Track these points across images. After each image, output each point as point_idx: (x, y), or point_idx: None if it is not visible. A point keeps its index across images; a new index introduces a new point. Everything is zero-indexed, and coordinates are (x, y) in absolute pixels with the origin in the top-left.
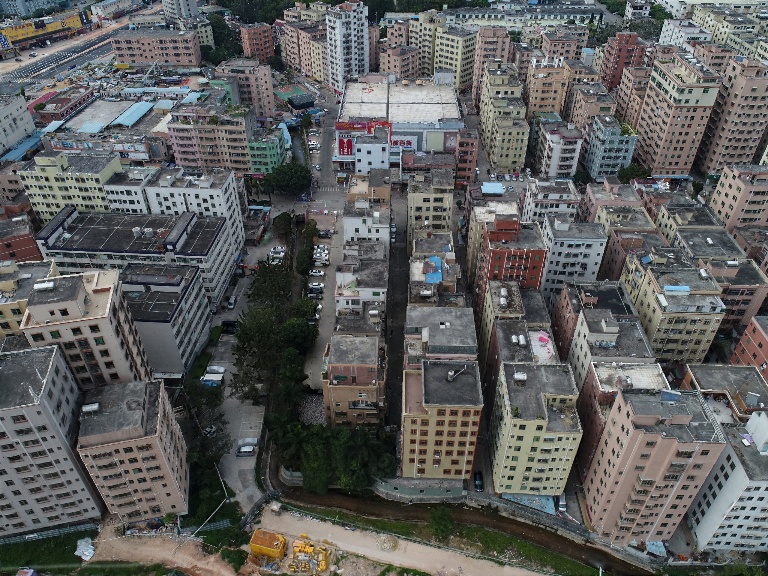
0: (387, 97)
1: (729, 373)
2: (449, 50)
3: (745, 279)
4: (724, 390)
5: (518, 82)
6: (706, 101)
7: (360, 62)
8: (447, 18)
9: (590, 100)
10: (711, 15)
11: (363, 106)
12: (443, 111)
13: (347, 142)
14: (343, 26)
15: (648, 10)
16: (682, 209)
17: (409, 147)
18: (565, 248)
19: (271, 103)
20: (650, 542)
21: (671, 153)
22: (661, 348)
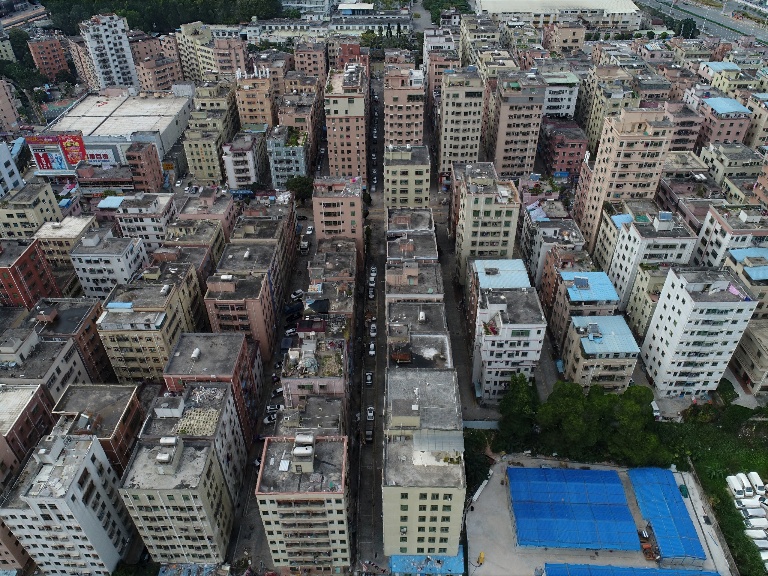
0: (114, 110)
1: (107, 393)
2: (208, 62)
3: (242, 294)
4: (77, 412)
5: (228, 94)
6: (355, 111)
7: (126, 75)
8: (251, 30)
9: (288, 111)
10: (465, 24)
11: (80, 120)
12: (155, 124)
13: (43, 156)
14: (93, 39)
15: (457, 19)
16: (246, 222)
17: (107, 160)
18: (85, 264)
19: (7, 117)
20: (4, 571)
21: (340, 164)
22: (124, 366)
